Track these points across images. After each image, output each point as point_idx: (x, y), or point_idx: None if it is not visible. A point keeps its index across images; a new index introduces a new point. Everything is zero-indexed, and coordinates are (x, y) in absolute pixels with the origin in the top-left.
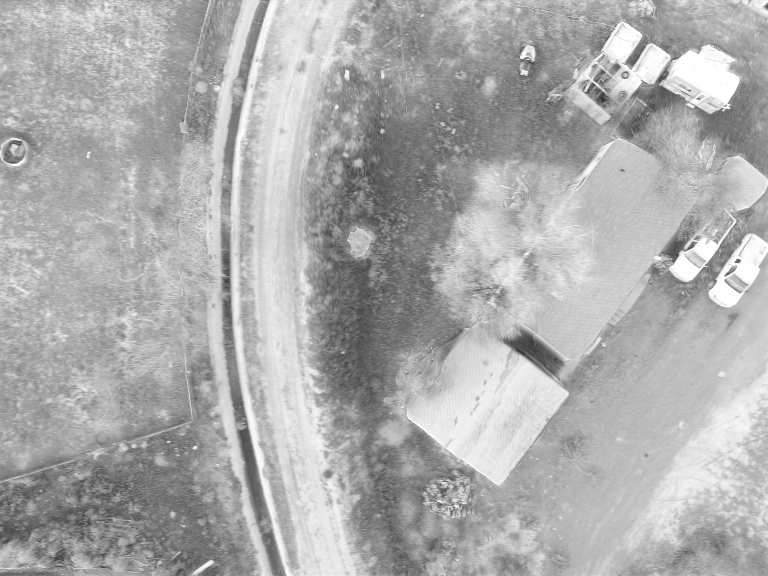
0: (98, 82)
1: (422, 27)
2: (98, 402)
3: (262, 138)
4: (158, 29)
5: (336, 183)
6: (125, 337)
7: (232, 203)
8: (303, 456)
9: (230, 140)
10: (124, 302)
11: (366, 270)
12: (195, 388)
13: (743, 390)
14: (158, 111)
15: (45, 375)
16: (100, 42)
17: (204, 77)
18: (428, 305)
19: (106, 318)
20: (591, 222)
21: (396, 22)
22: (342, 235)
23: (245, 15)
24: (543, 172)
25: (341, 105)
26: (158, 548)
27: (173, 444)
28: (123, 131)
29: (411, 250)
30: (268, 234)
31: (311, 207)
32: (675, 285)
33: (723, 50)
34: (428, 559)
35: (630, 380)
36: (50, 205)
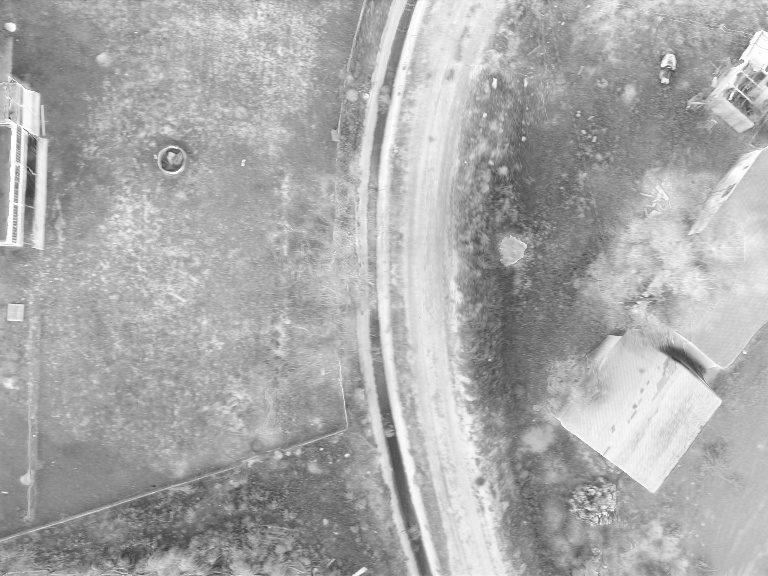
0: (252, 90)
1: (563, 35)
2: (253, 410)
3: (411, 146)
4: (309, 37)
5: (484, 191)
6: (279, 345)
7: (379, 211)
8: (454, 463)
9: (375, 148)
10: (278, 310)
11: (509, 277)
12: (347, 395)
13: None
14: (309, 119)
15: (202, 383)
16: (253, 50)
17: (354, 85)
18: (570, 312)
19: (261, 326)
20: (743, 230)
21: (539, 30)
22: (489, 243)
23: (391, 23)
24: (682, 180)
25: (489, 113)
26: (314, 555)
27: (326, 451)
28: (276, 139)
29: (553, 257)
30: (418, 242)
31: (461, 215)
32: None
33: None
34: (574, 566)
35: None
36: (206, 213)
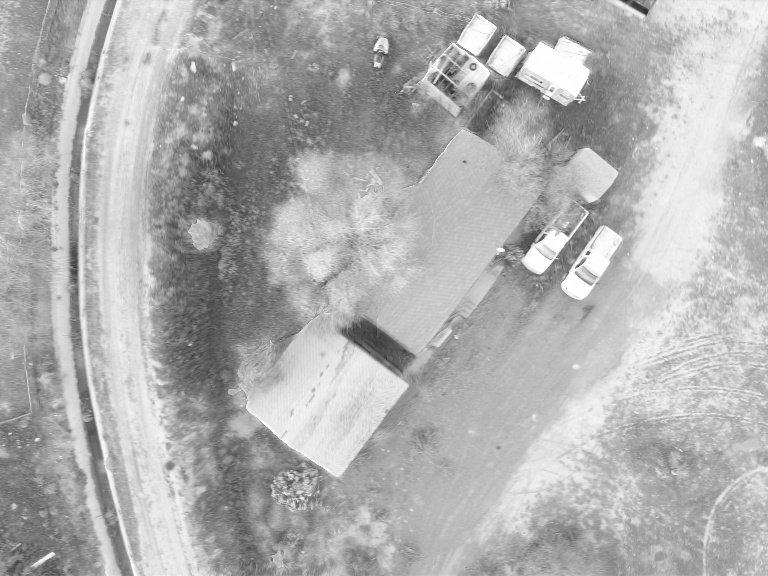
0: None
1: (276, 19)
2: None
3: (107, 130)
4: (1, 21)
5: (182, 175)
6: None
7: (80, 195)
8: (146, 448)
9: (79, 132)
10: None
11: (217, 262)
12: (37, 380)
13: (598, 382)
14: (1, 103)
15: None
16: None
17: (48, 69)
18: (280, 297)
19: None
20: (432, 214)
21: (247, 14)
22: (189, 227)
23: (93, 7)
24: (397, 164)
25: (187, 97)
26: None
27: (14, 436)
28: None
29: (263, 242)
30: (112, 226)
31: (155, 199)
32: (529, 277)
33: (579, 42)
34: (276, 551)
35: (483, 372)
36: None
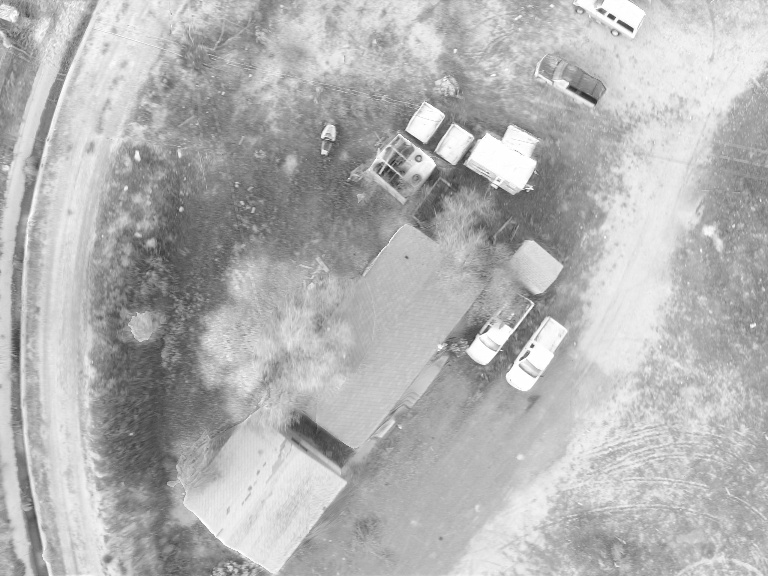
0: None
1: (223, 105)
2: None
3: (50, 219)
4: None
5: (125, 265)
6: None
7: (22, 282)
8: (84, 540)
9: (23, 218)
10: None
11: (161, 349)
12: None
13: (542, 473)
14: None
15: None
16: None
17: None
18: (223, 385)
19: None
20: (373, 309)
21: (194, 101)
22: (131, 316)
23: (38, 94)
24: (344, 252)
25: (131, 186)
26: None
27: None
28: None
29: (207, 329)
30: (53, 316)
31: (97, 289)
32: (474, 367)
33: (528, 130)
34: None
35: (426, 462)
36: None
